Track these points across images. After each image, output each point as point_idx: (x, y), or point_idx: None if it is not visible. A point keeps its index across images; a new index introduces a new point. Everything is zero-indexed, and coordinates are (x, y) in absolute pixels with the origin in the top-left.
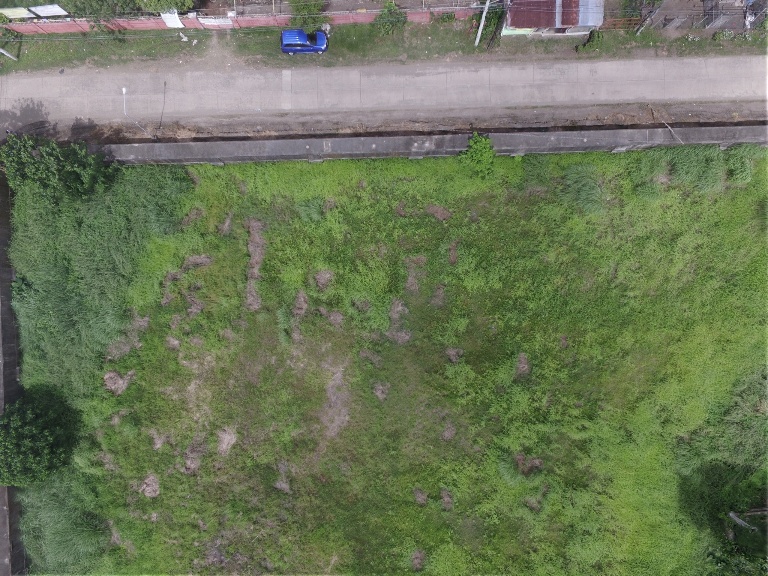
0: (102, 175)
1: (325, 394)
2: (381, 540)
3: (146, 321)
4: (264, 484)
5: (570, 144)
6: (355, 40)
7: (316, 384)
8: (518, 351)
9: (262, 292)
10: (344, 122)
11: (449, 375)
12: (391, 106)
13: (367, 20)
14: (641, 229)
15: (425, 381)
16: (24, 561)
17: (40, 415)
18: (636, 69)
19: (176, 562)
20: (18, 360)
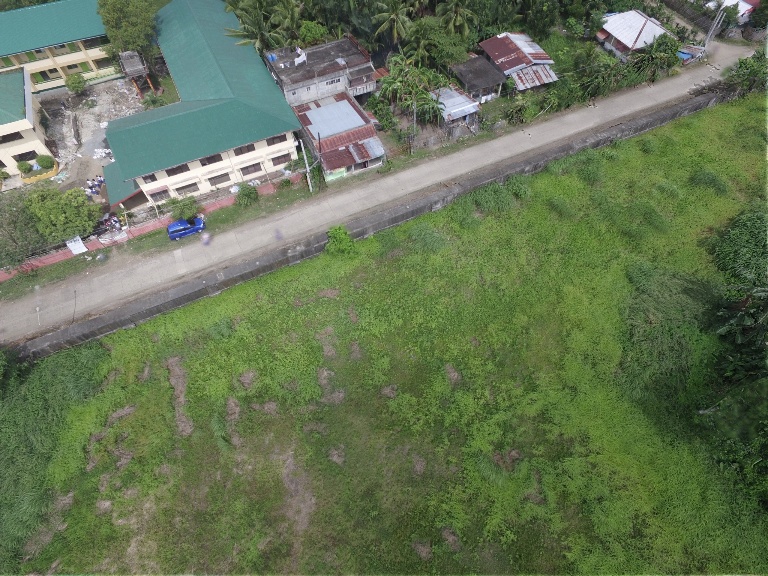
0: (18, 370)
1: (282, 486)
2: None
3: (71, 497)
4: None
5: (399, 212)
6: (224, 216)
7: (270, 479)
8: (442, 364)
9: (192, 413)
10: (231, 265)
11: (393, 410)
12: (265, 243)
13: (229, 203)
14: (481, 246)
15: (375, 426)
16: None
17: None
18: (422, 170)
19: None
20: None
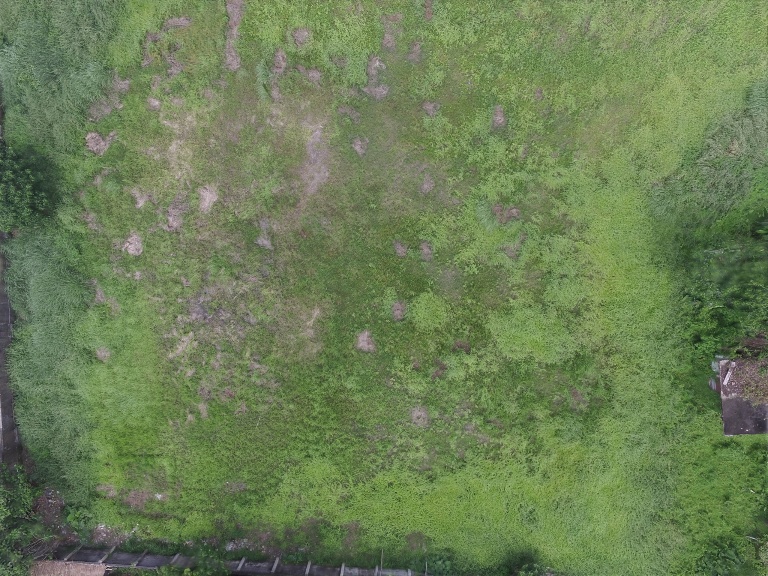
0: None
1: (305, 151)
2: (362, 293)
3: (127, 84)
4: (246, 239)
5: None
6: None
7: (296, 141)
8: (494, 104)
9: (241, 50)
10: None
11: (426, 127)
12: None
13: None
14: None
15: (403, 135)
16: (9, 316)
17: (22, 158)
18: None
19: (160, 318)
20: (0, 120)
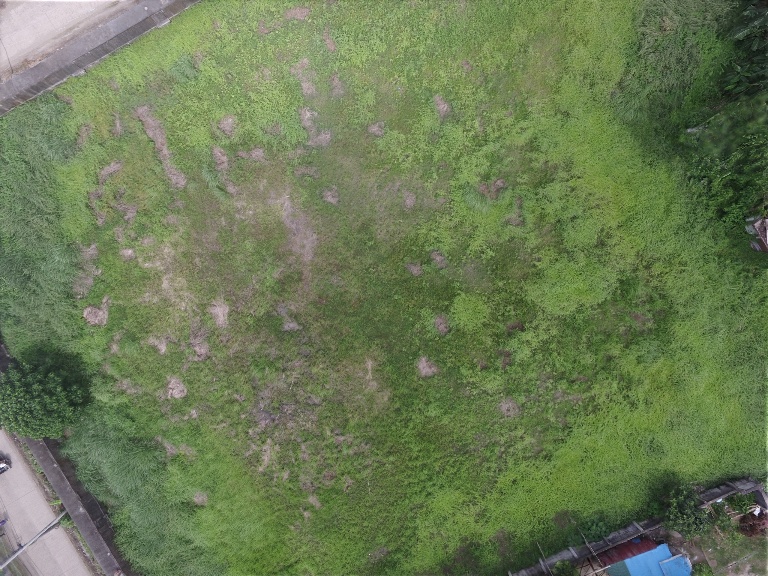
0: None
1: (284, 226)
2: (401, 325)
3: (94, 249)
4: (273, 332)
5: None
6: None
7: (271, 221)
8: (431, 96)
9: (180, 166)
10: None
11: (382, 148)
12: None
13: None
14: None
15: (365, 166)
16: (100, 509)
17: (39, 365)
18: None
19: (234, 441)
20: None
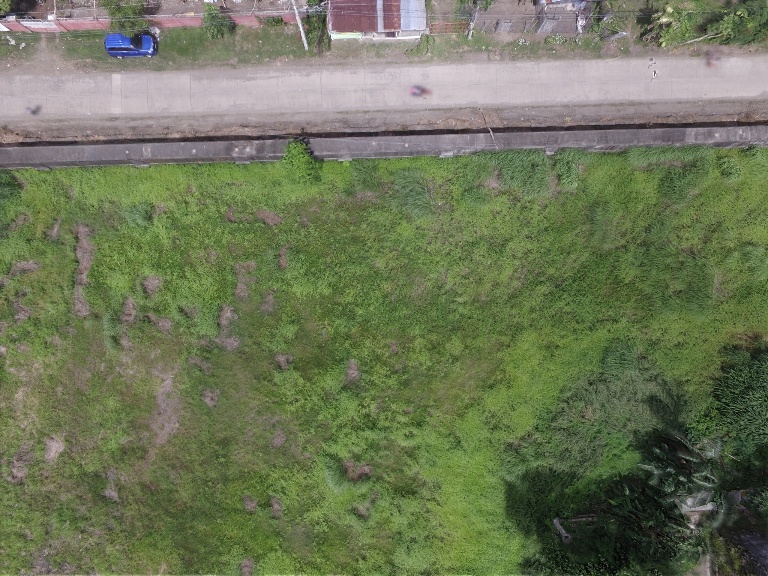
0: None
1: (154, 401)
2: (210, 548)
3: None
4: (92, 492)
5: (391, 149)
6: (185, 44)
7: (145, 391)
8: (348, 357)
9: (89, 298)
10: (175, 127)
11: (277, 382)
12: (222, 110)
13: (196, 24)
14: (470, 234)
15: (254, 388)
16: None
17: None
18: (468, 73)
19: (3, 572)
20: None
